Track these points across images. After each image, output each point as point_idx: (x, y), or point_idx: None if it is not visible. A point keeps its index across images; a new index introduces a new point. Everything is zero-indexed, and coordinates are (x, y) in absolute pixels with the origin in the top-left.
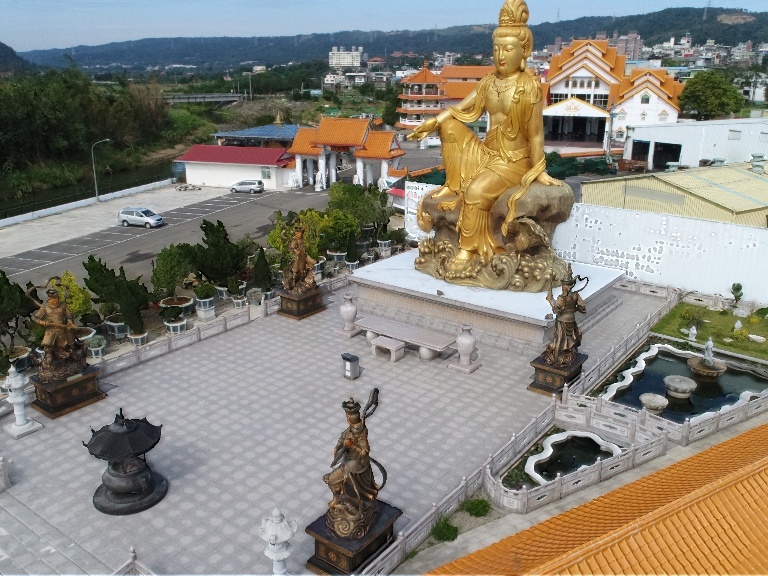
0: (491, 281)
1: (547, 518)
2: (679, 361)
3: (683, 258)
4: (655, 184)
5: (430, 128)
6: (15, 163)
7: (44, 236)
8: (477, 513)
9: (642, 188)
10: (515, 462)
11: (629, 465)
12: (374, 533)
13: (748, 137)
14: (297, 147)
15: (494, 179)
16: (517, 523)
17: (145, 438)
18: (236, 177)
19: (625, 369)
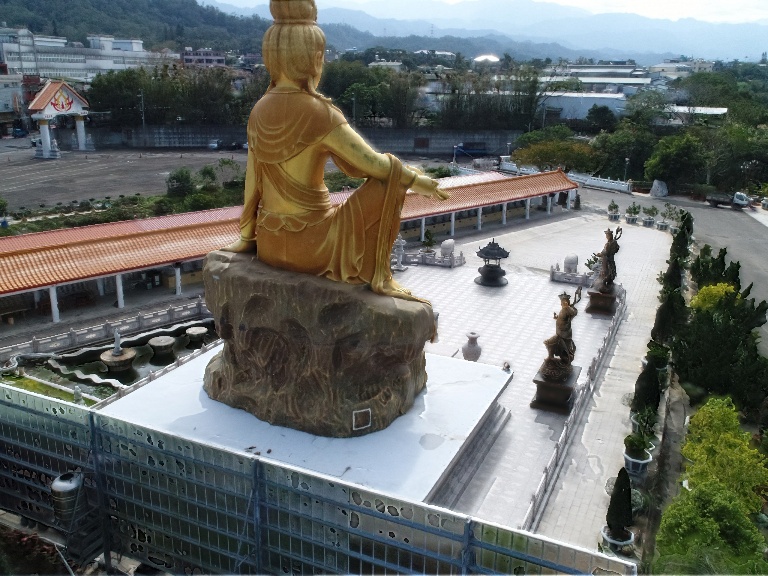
0: None
1: None
2: None
3: None
4: None
5: None
6: None
7: None
8: None
9: None
10: None
11: None
12: None
13: None
14: None
15: None
16: None
17: None
18: None
19: None
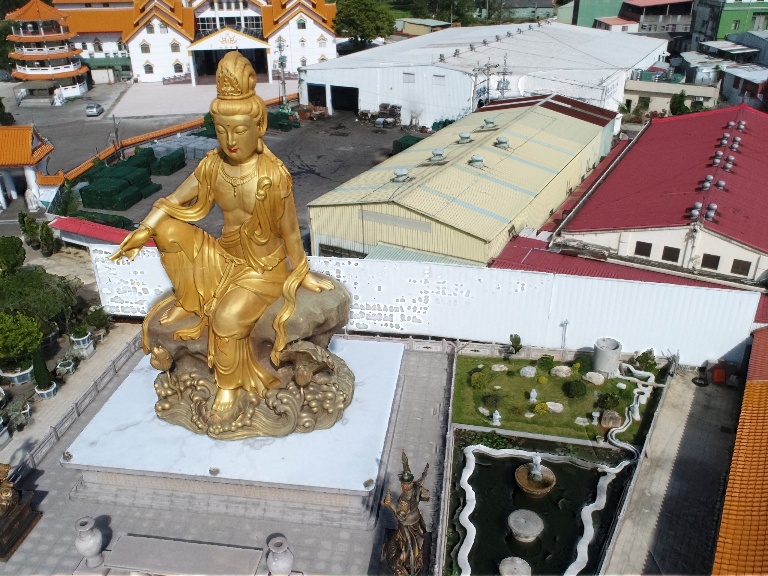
0: (271, 425)
1: None
2: (496, 463)
3: (451, 306)
4: (396, 210)
5: (142, 243)
6: None
7: None
8: None
9: (381, 213)
10: None
11: None
12: None
13: (422, 80)
14: None
15: (250, 300)
16: None
17: None
18: None
19: (457, 507)
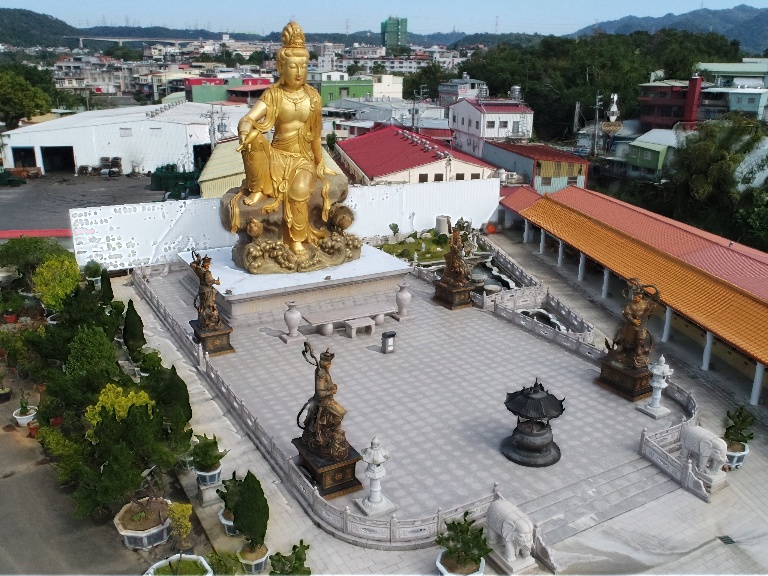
0: (331, 260)
1: (599, 339)
2: None
3: None
4: None
5: None
6: None
7: None
8: None
9: None
10: None
11: None
12: None
13: (139, 133)
14: None
15: None
16: (602, 346)
17: None
18: None
19: None
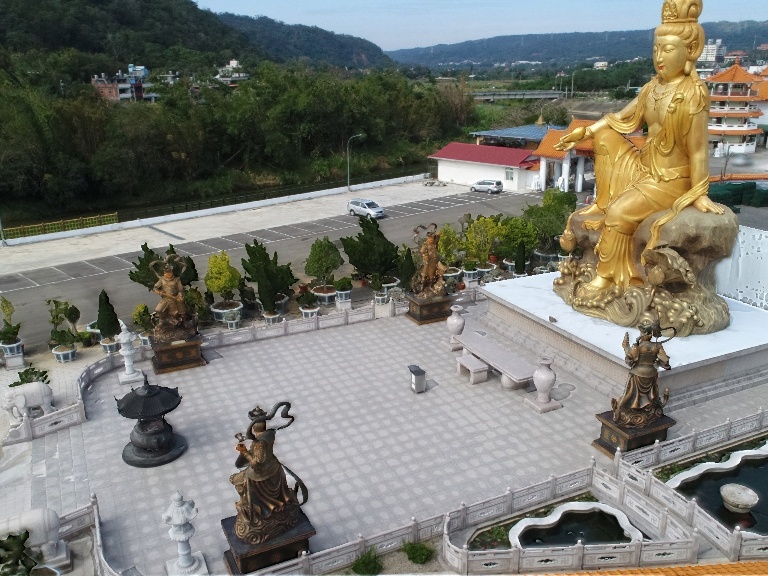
0: (619, 315)
1: None
2: None
3: None
4: None
5: (578, 138)
6: (321, 151)
7: (283, 218)
8: (413, 558)
9: None
10: (507, 519)
11: (632, 561)
12: (270, 543)
13: None
14: (543, 149)
15: (638, 199)
16: None
17: (158, 405)
18: (481, 176)
19: (743, 449)
